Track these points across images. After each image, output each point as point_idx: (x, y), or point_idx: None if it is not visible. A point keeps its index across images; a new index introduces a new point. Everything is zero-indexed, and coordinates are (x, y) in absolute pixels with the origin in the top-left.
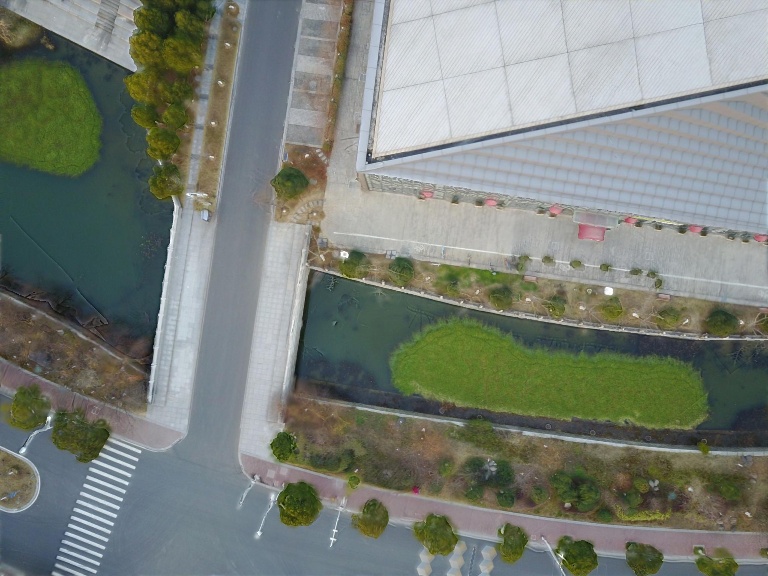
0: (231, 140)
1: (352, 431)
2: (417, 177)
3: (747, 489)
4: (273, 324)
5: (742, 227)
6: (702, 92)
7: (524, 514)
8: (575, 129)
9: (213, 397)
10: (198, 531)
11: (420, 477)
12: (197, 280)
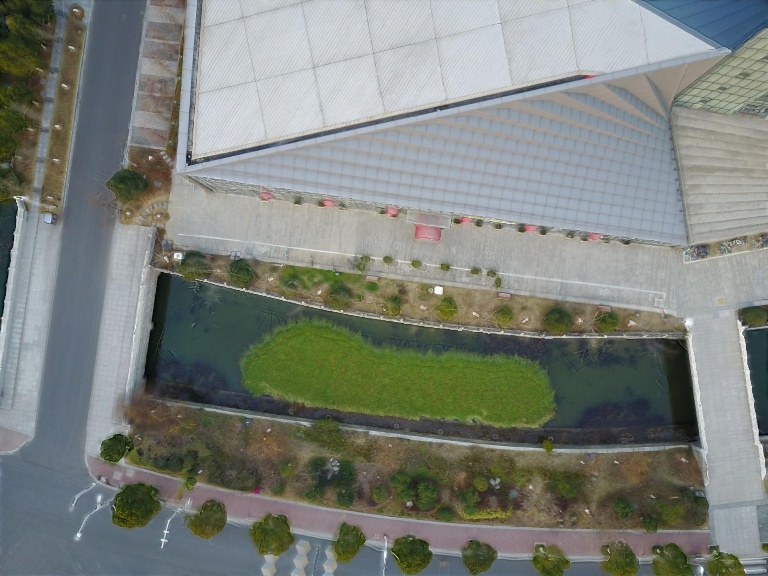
0: (76, 143)
1: (197, 432)
2: (239, 178)
3: (587, 486)
4: (119, 326)
5: (570, 226)
6: (503, 92)
7: (368, 513)
8: (384, 129)
9: (59, 399)
10: (44, 534)
11: (263, 477)
12: (43, 283)
